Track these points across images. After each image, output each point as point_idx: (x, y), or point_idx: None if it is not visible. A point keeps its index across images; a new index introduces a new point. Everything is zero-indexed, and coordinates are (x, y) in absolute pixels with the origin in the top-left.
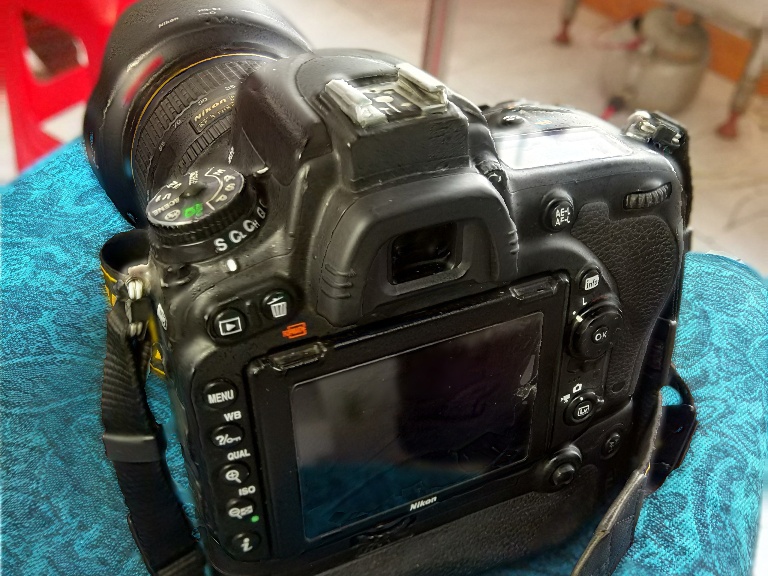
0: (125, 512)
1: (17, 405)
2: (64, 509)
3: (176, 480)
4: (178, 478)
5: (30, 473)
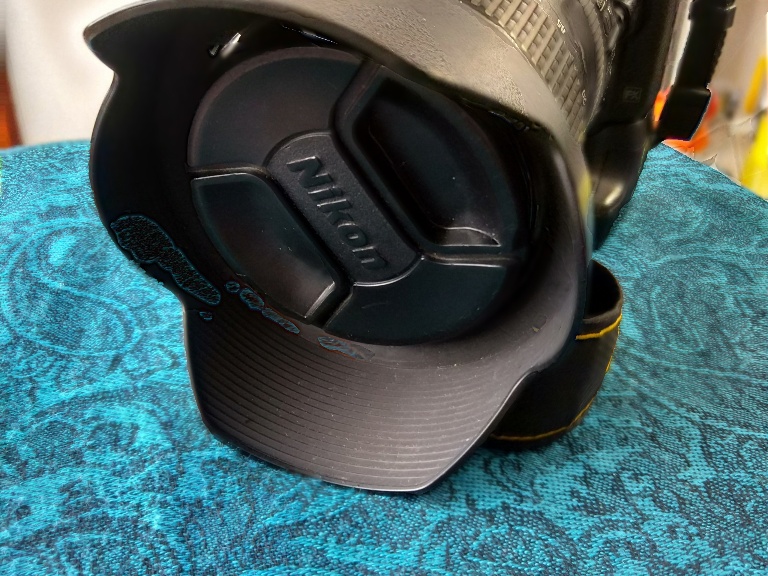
0: (674, 279)
1: (766, 388)
2: (730, 302)
3: (617, 274)
4: (615, 274)
5: (759, 337)
